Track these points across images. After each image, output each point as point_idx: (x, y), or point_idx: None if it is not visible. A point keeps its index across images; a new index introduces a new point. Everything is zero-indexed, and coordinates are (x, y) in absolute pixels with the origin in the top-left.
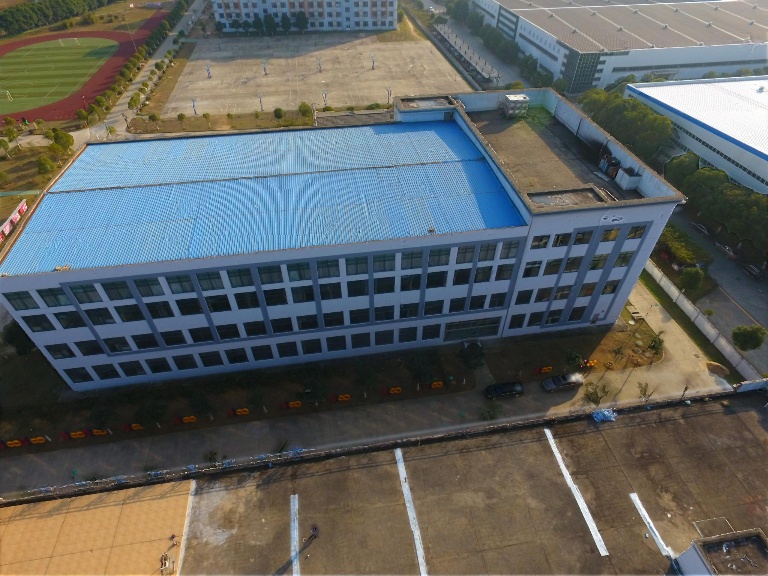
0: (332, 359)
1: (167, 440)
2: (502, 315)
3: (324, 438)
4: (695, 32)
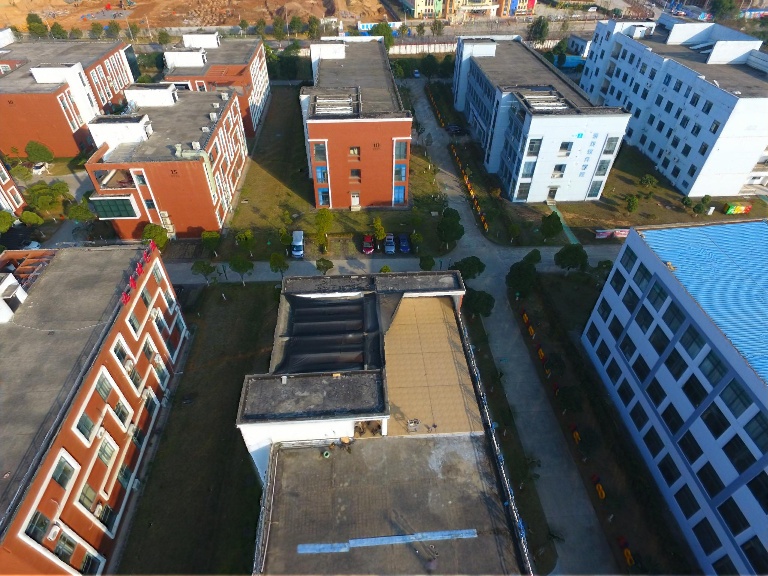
0: None
1: (552, 423)
2: None
3: None
4: None
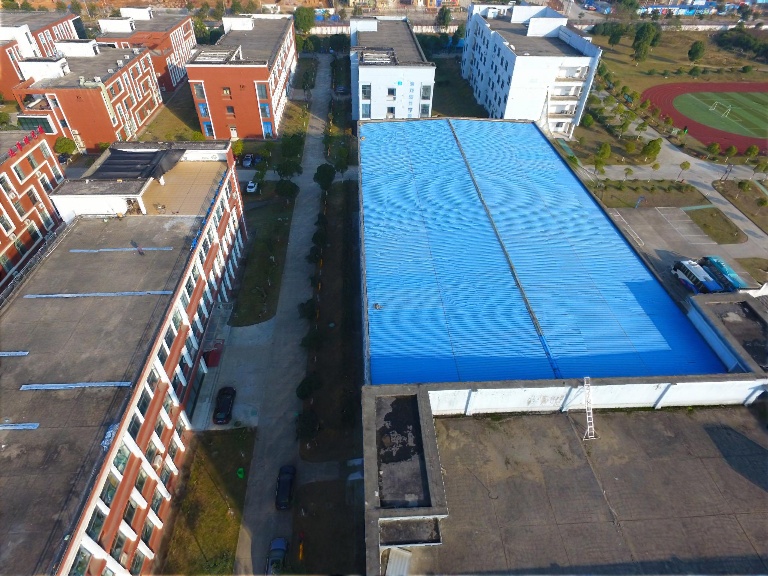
0: None
1: None
2: None
3: (284, 333)
4: None
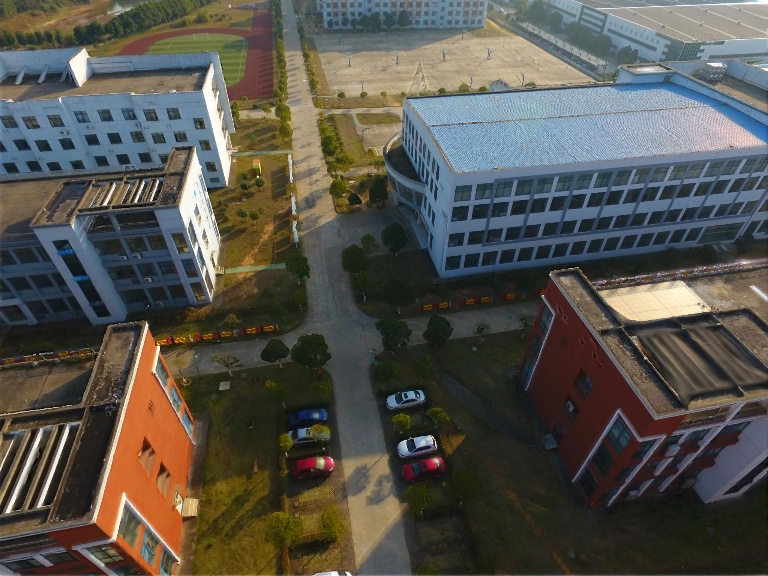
0: (619, 256)
1: (535, 305)
2: (745, 221)
3: None
4: (765, 27)
